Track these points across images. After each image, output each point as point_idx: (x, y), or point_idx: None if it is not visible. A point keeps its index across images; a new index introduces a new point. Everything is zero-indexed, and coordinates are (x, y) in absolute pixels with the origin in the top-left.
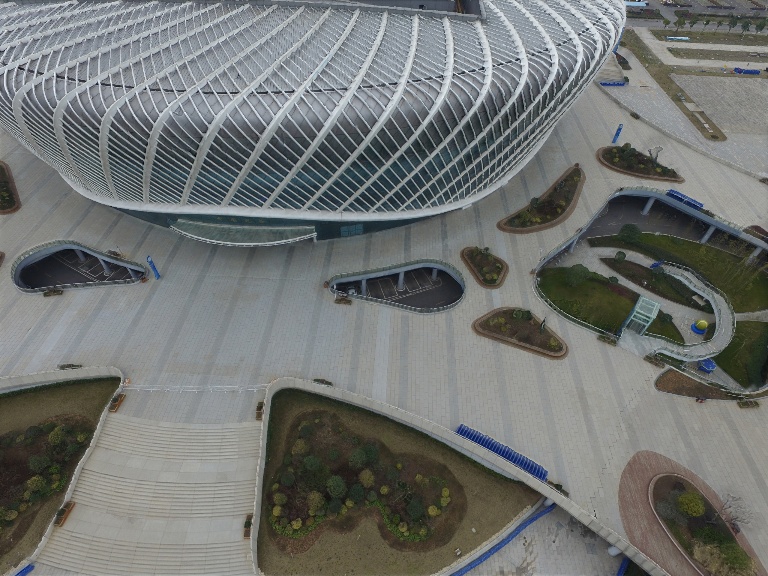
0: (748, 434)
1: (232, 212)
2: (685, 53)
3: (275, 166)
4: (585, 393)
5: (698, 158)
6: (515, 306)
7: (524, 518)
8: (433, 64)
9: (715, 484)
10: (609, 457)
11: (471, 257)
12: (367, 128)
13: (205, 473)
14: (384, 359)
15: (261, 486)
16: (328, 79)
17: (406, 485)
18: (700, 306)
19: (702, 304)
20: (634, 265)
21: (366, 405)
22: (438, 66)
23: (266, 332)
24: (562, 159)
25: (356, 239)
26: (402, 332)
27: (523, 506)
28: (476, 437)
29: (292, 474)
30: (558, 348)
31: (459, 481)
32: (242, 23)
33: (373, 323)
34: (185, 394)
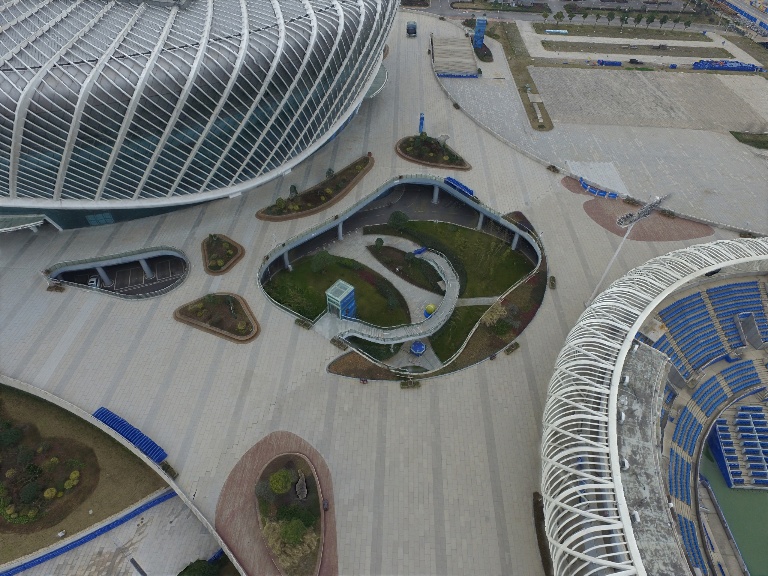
0: (394, 413)
1: None
2: (557, 46)
3: None
4: (252, 376)
5: (497, 147)
6: (229, 292)
7: (149, 499)
8: (94, 48)
9: (333, 462)
10: (241, 437)
11: (208, 244)
12: (9, 112)
13: None
14: (66, 345)
15: None
16: None
17: (37, 468)
18: (441, 291)
19: (444, 289)
20: (397, 252)
21: (25, 390)
22: (99, 50)
23: None
24: (359, 148)
25: (105, 228)
26: (100, 318)
27: (156, 488)
28: (109, 419)
29: None
30: (245, 332)
31: (99, 464)
32: None
33: (75, 310)
34: None
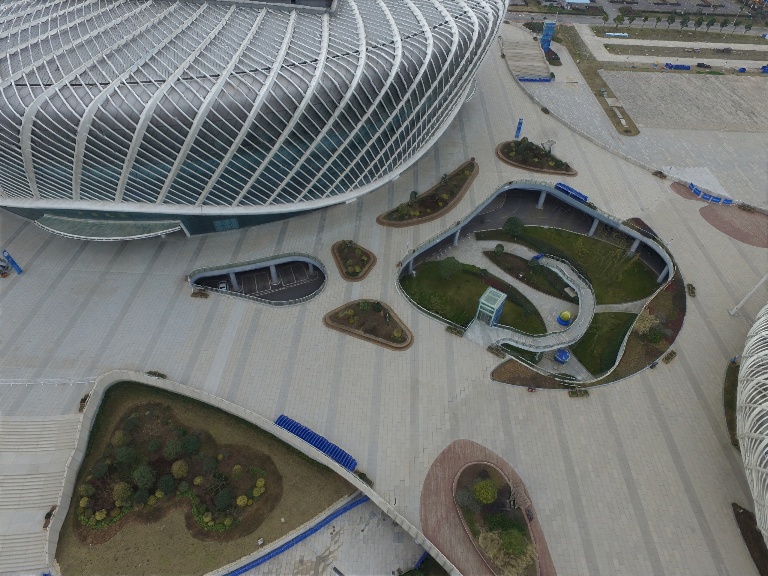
0: (571, 422)
1: (85, 206)
2: (620, 49)
3: (106, 159)
4: (418, 383)
5: (597, 152)
6: (372, 298)
7: (337, 507)
8: (264, 56)
9: (523, 472)
10: (425, 446)
11: (340, 250)
12: (188, 120)
13: (18, 465)
14: (226, 351)
15: (73, 478)
16: (149, 71)
17: (222, 476)
18: (570, 298)
19: (572, 296)
20: (515, 258)
21: (196, 397)
22: (268, 58)
23: (114, 325)
24: (460, 153)
25: (231, 233)
26: (251, 325)
27: (340, 496)
28: (293, 427)
29: (104, 465)
30: (401, 339)
31: (279, 471)
32: (81, 17)
33: (224, 316)
34: (15, 387)
